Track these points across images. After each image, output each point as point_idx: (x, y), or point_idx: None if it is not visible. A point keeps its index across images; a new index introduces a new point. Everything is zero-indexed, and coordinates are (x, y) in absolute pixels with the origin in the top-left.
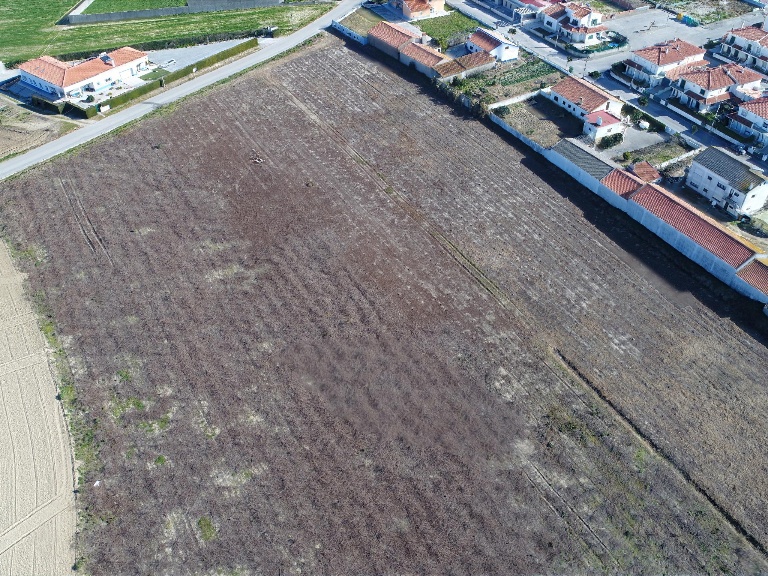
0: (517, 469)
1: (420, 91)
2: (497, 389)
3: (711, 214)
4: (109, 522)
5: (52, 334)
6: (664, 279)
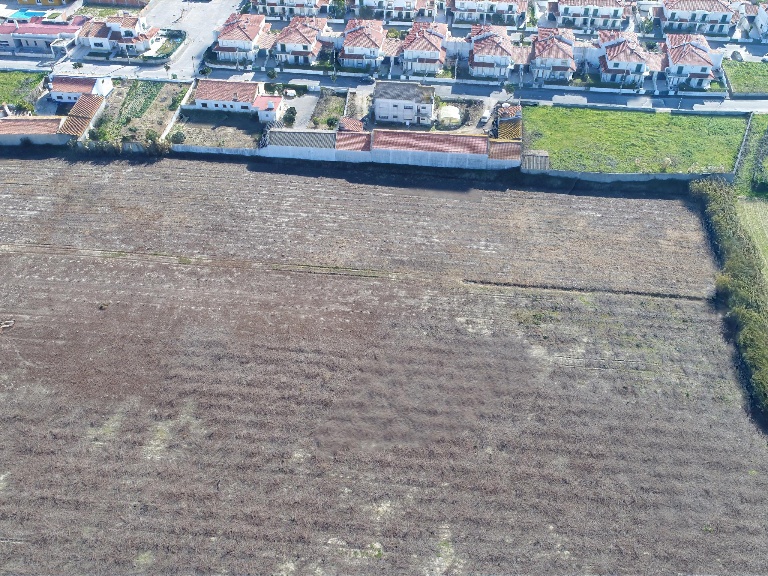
0: (554, 367)
1: (68, 162)
2: (476, 333)
3: None
4: None
5: None
6: (450, 190)
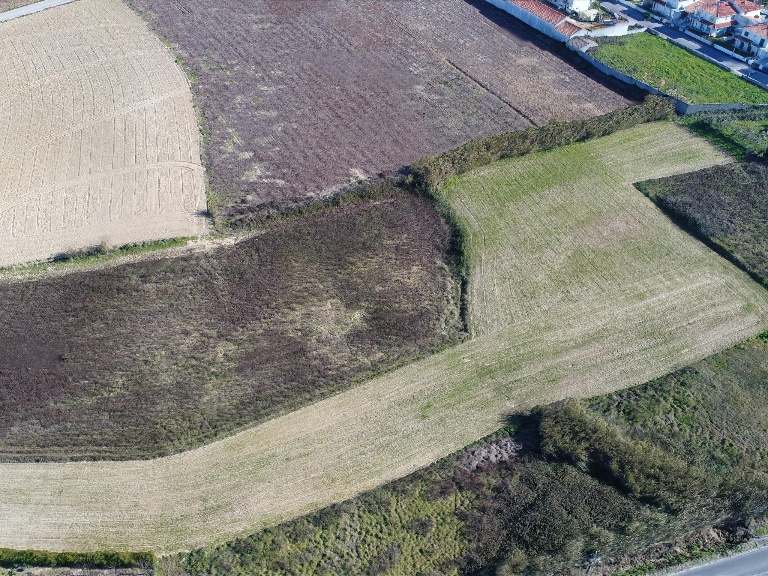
0: (414, 93)
1: None
2: (410, 70)
3: None
4: (208, 96)
5: (168, 43)
6: (517, 37)
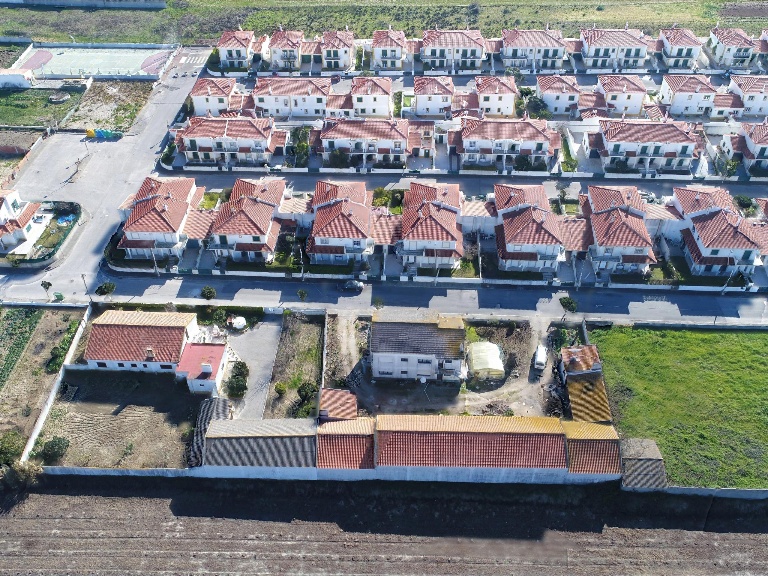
0: None
1: None
2: None
3: (436, 397)
4: None
5: None
6: (511, 538)
